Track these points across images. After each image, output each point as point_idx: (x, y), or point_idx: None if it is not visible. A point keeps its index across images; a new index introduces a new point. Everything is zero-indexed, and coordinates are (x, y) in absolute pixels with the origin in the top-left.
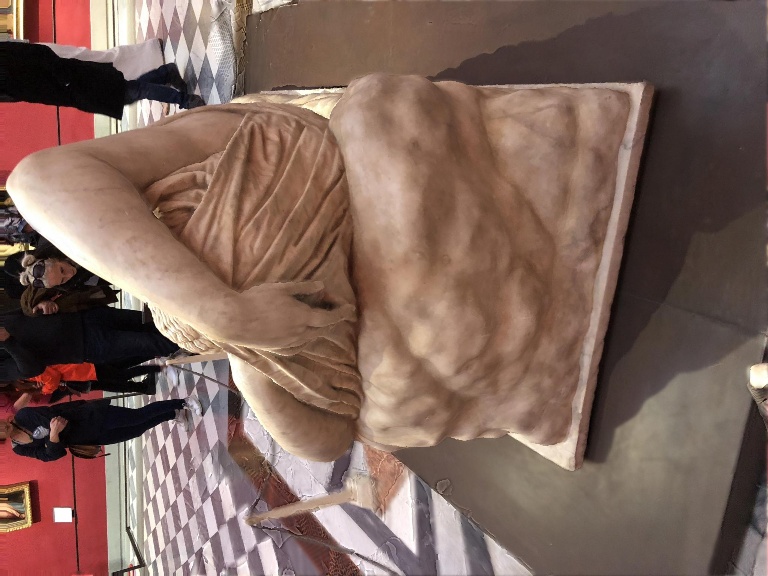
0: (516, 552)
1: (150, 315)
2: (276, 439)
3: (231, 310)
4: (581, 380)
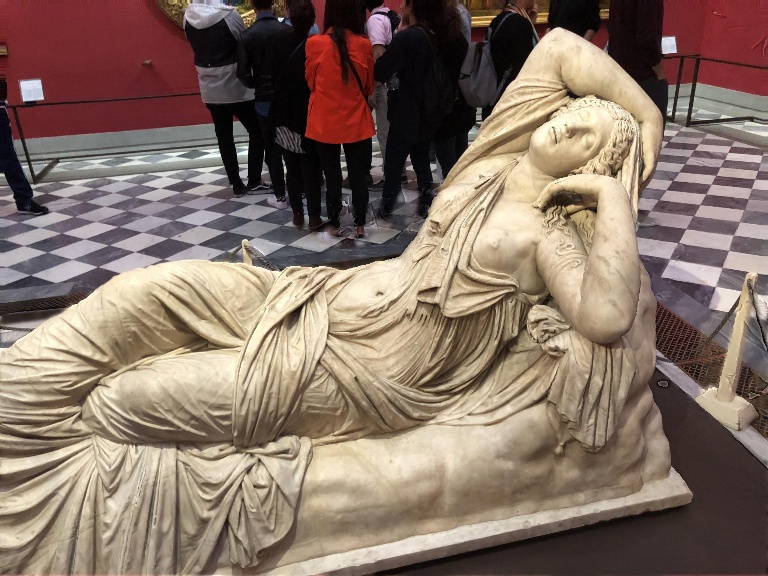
0: None
1: None
2: (630, 241)
3: None
4: None
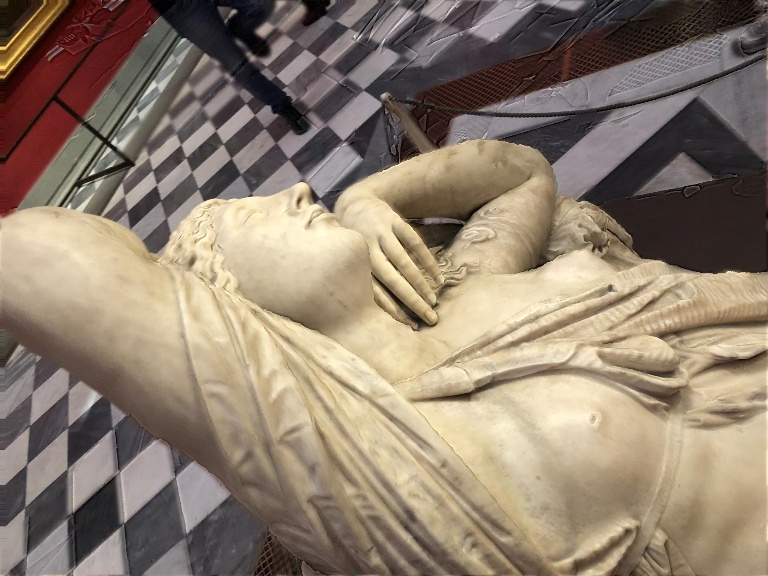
0: (605, 208)
1: None
2: None
3: None
4: None
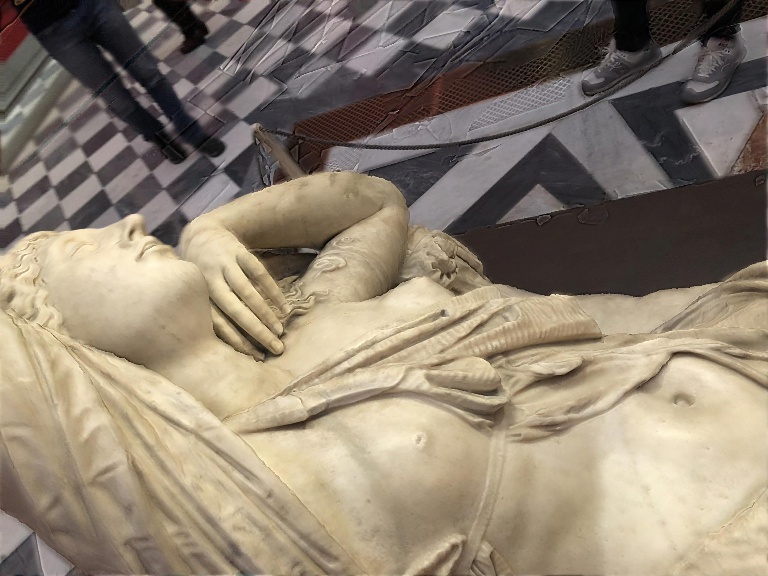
0: (468, 236)
1: None
2: None
3: None
4: None
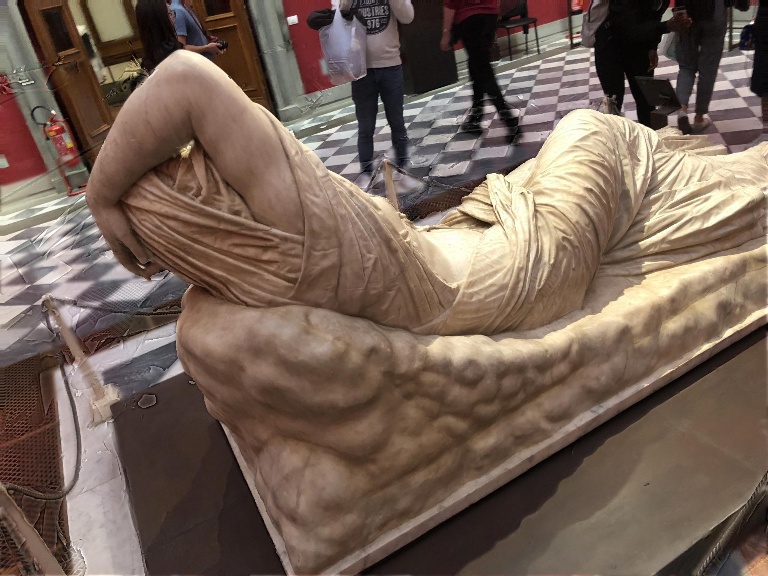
0: None
1: (643, 84)
2: None
3: (88, 200)
4: (231, 435)
